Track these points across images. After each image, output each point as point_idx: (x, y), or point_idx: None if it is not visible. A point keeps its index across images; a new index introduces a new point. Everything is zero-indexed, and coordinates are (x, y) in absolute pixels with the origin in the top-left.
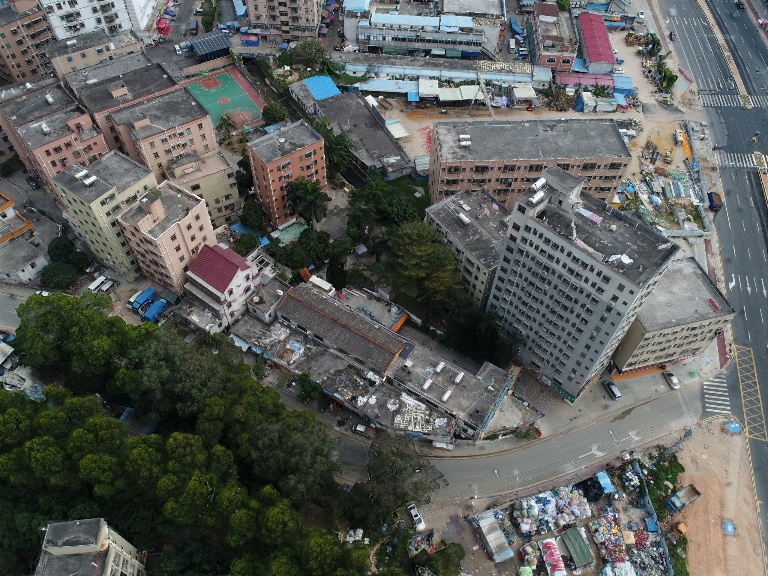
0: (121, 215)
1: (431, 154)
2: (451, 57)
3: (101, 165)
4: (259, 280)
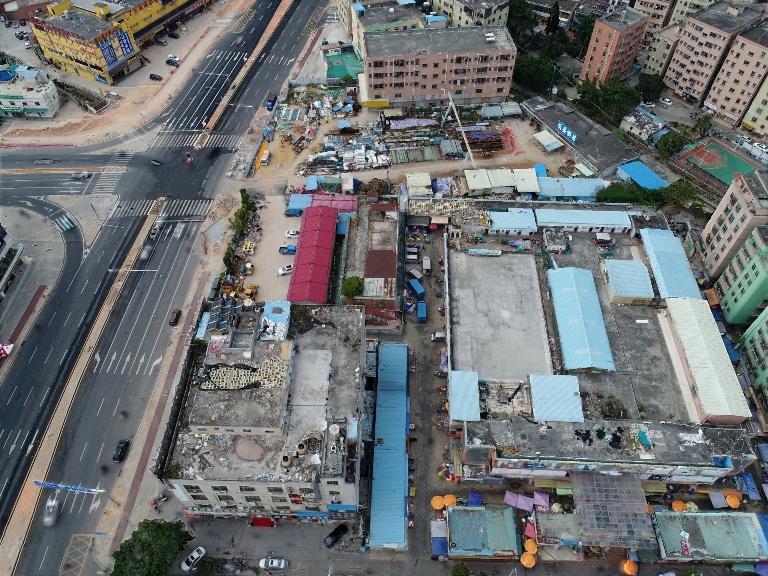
0: None
1: None
2: None
3: None
4: (596, 8)
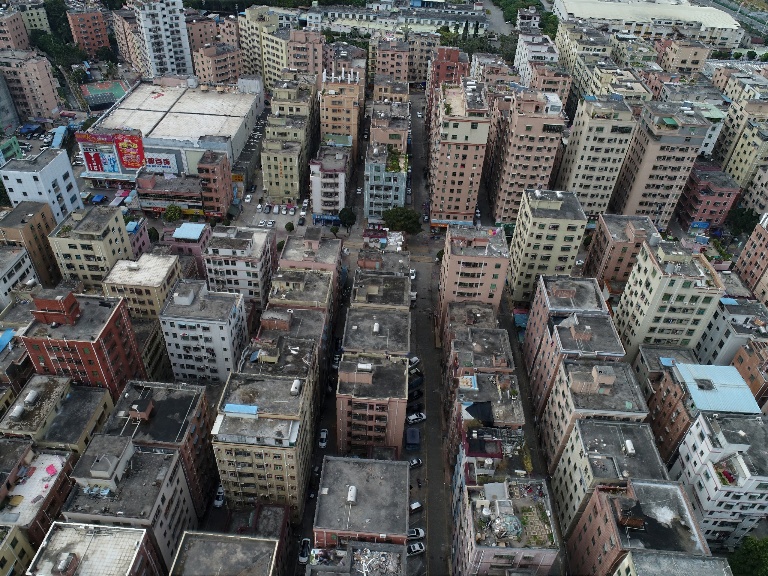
0: None
1: (13, 36)
2: None
3: None
4: None
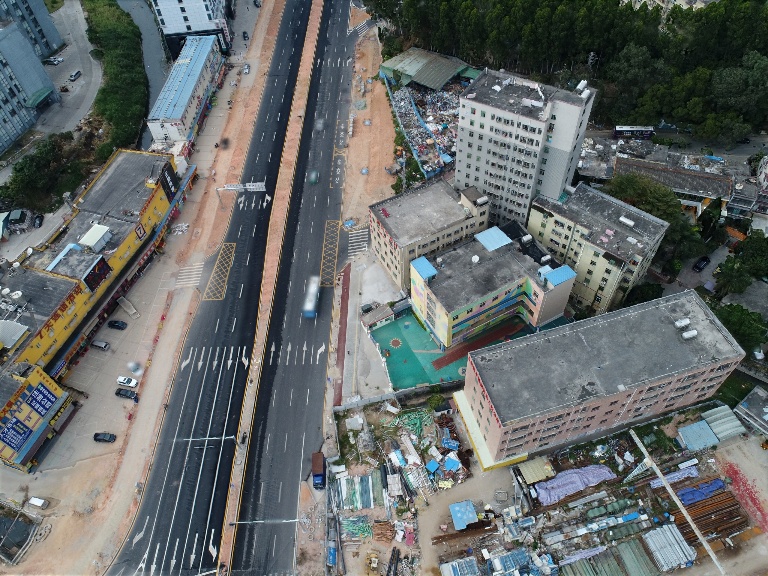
0: None
1: None
2: None
3: None
4: (765, 188)
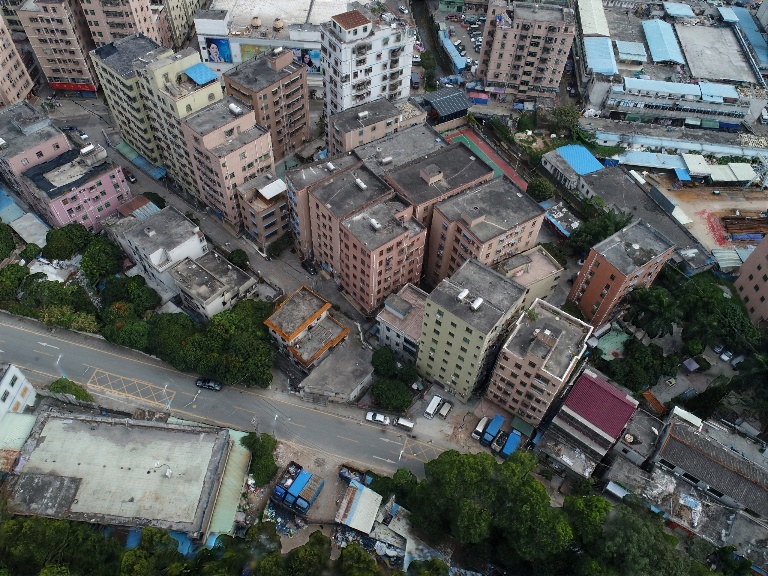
0: (507, 344)
1: (758, 256)
2: (705, 127)
3: (460, 276)
4: None
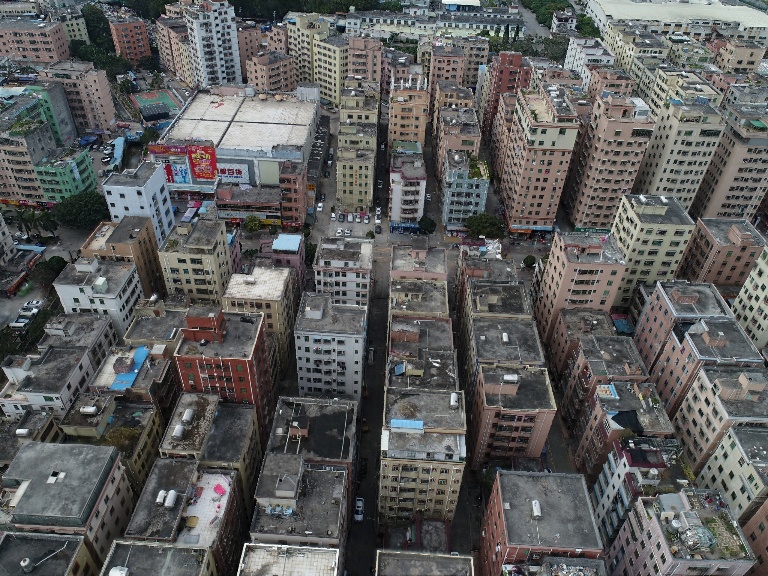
0: None
1: None
2: None
3: None
4: None
